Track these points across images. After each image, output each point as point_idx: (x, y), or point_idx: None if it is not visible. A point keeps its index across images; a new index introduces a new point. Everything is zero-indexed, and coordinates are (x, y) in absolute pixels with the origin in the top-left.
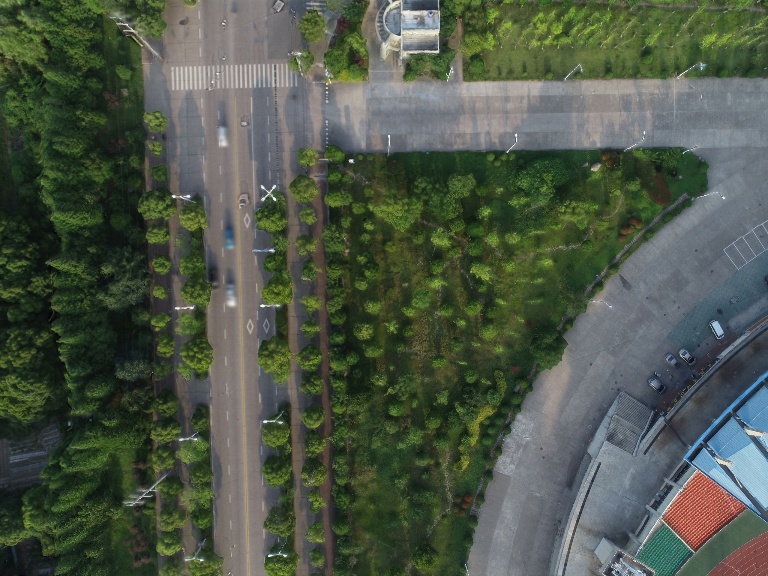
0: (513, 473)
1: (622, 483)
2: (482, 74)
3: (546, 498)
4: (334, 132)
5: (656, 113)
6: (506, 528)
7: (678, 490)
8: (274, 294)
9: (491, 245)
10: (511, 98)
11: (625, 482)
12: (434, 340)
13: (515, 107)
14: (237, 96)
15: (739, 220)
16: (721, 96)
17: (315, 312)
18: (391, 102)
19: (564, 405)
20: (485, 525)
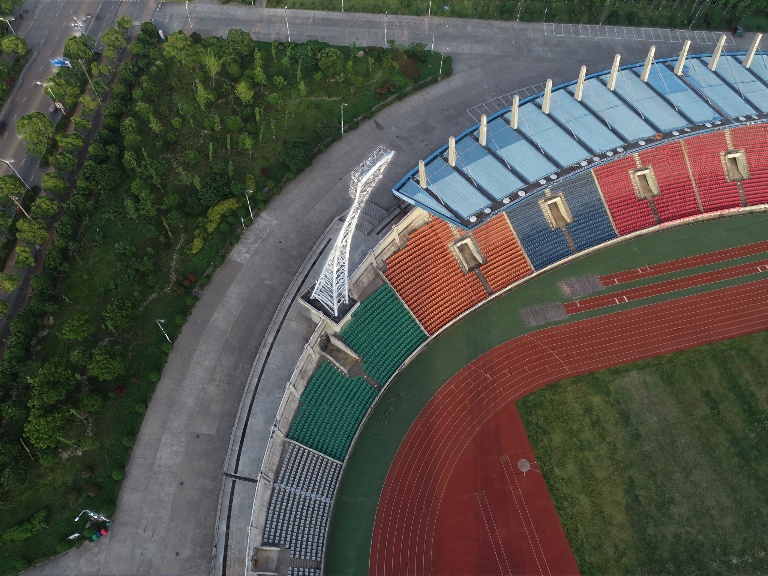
0: (247, 261)
1: (351, 258)
2: (280, 4)
3: (277, 286)
4: (157, 26)
5: (412, 32)
6: (227, 312)
7: (392, 230)
8: (54, 82)
9: (264, 92)
10: (300, 18)
11: (355, 257)
12: (196, 149)
13: (302, 22)
14: (90, 3)
15: (479, 94)
16: (463, 27)
17: (95, 125)
18: (207, 14)
19: (310, 208)
20: (204, 307)
